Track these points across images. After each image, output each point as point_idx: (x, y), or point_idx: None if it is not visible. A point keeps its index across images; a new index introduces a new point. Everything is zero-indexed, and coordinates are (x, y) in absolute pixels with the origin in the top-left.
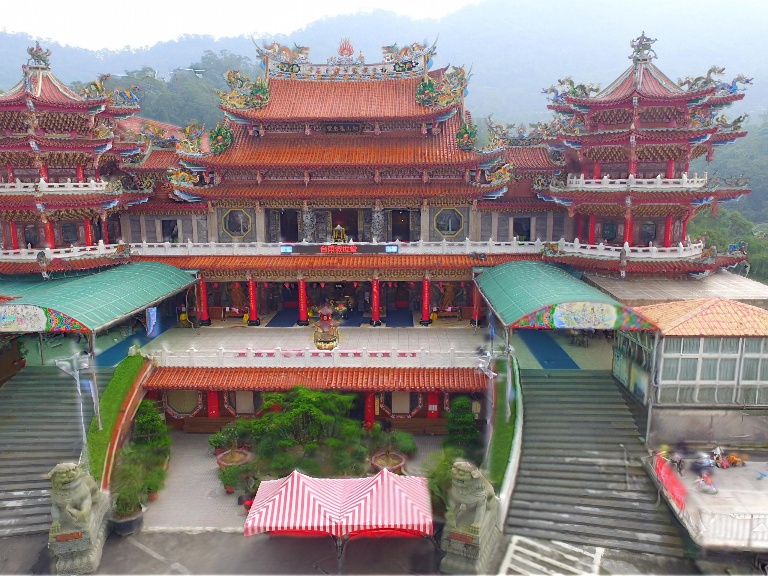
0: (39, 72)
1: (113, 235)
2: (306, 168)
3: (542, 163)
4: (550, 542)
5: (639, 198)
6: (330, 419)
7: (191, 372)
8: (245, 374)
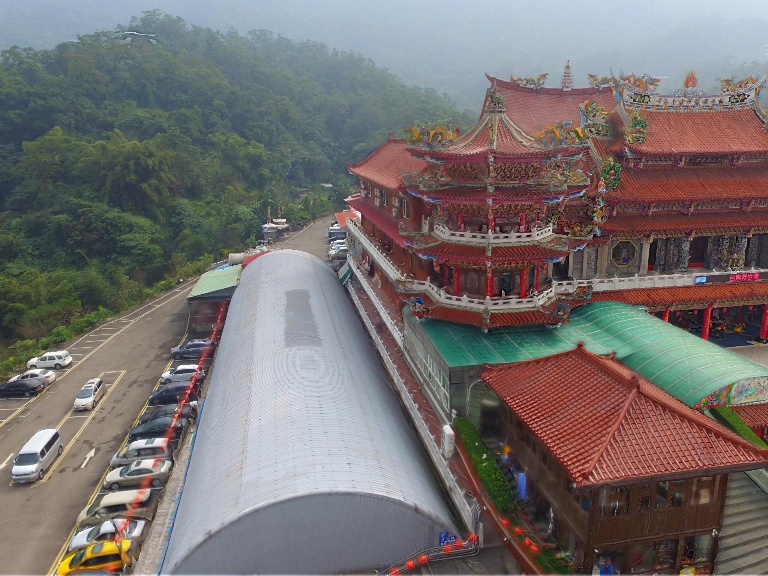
0: (504, 116)
1: None
2: None
3: None
4: None
5: None
6: None
7: (748, 410)
8: None
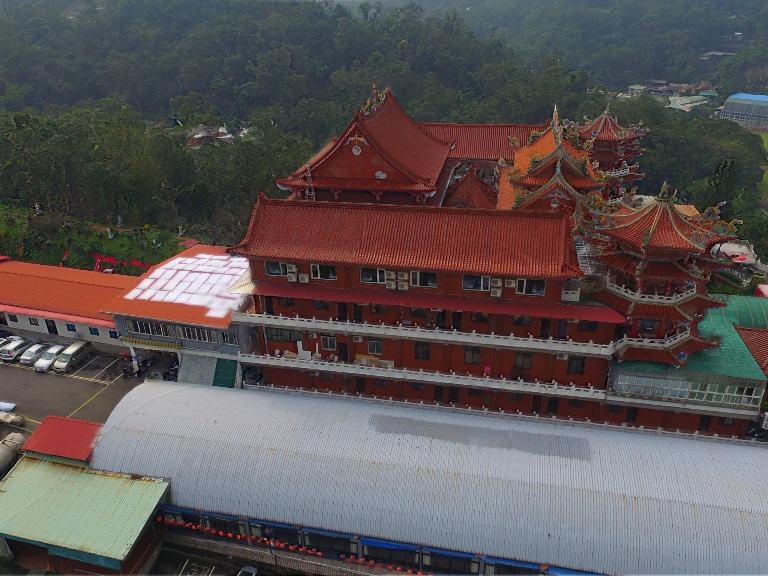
0: None
1: None
2: None
3: None
4: None
5: None
6: None
7: None
8: None
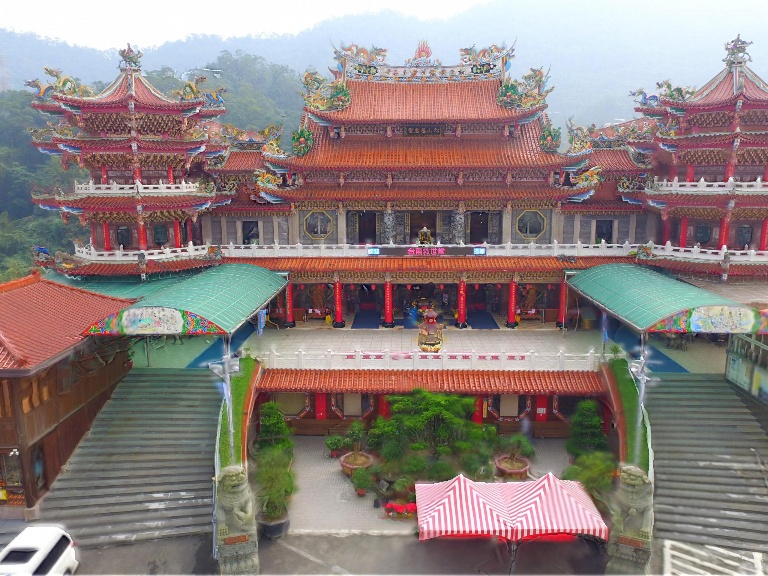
0: (131, 74)
1: (194, 236)
2: (390, 170)
3: (626, 166)
4: (704, 547)
5: (742, 201)
6: (460, 422)
7: (300, 374)
8: (355, 376)
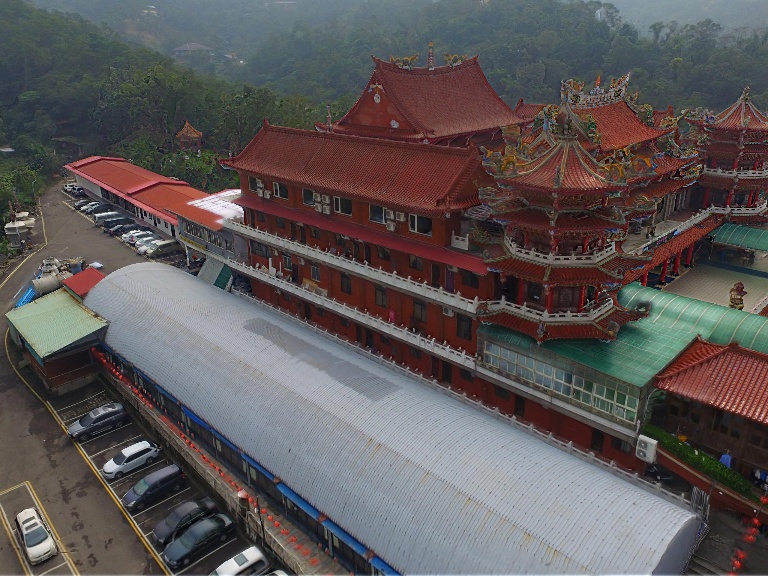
0: None
1: None
2: None
3: None
4: None
5: None
6: None
7: None
8: None
